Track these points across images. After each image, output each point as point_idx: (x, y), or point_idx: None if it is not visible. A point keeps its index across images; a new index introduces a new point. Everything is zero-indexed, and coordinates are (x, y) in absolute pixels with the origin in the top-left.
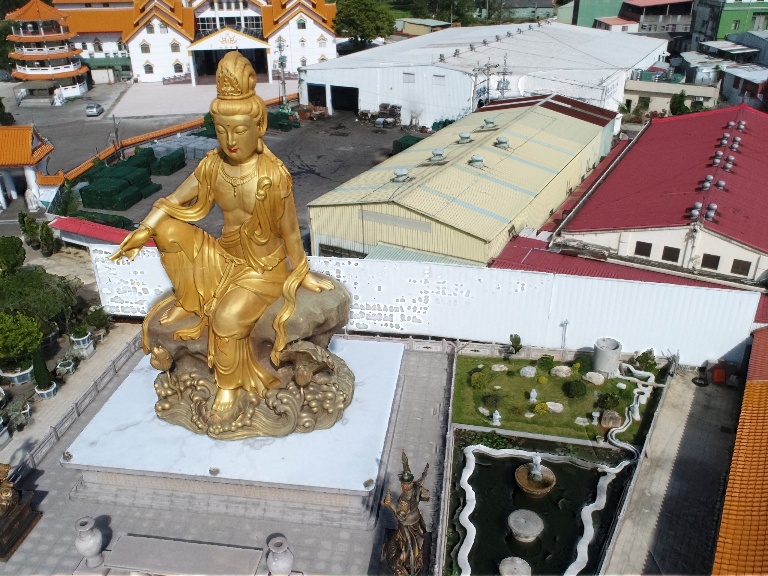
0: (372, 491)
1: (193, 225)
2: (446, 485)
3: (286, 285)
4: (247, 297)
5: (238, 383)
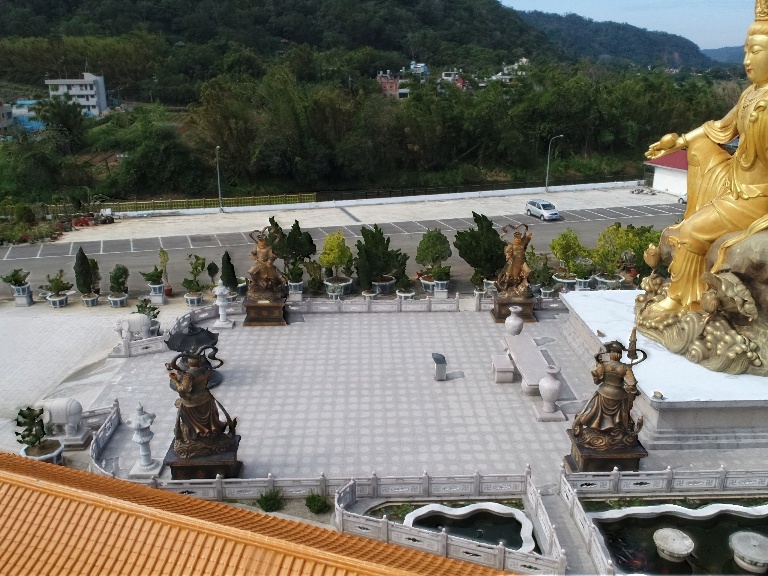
0: (654, 402)
1: (725, 150)
2: (759, 490)
3: (757, 221)
4: (710, 214)
5: (678, 294)
